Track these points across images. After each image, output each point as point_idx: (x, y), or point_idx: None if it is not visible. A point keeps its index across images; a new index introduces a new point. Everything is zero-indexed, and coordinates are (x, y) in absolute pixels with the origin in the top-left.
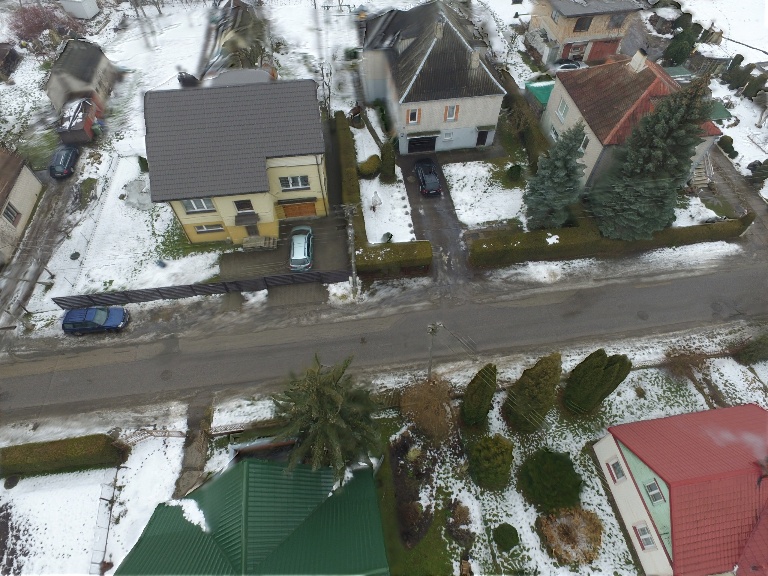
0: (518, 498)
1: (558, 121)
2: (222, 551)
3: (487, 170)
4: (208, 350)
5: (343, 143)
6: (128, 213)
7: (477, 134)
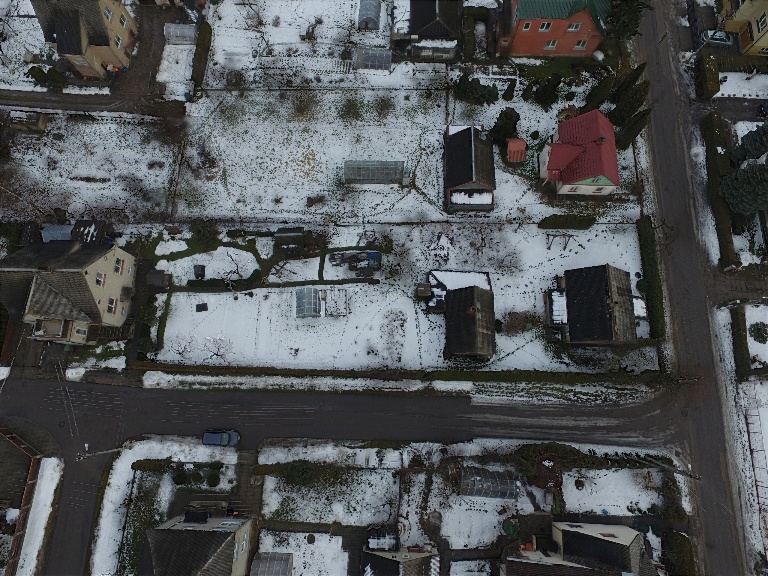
0: (583, 105)
1: None
2: None
3: None
4: (655, 3)
5: None
6: None
7: None
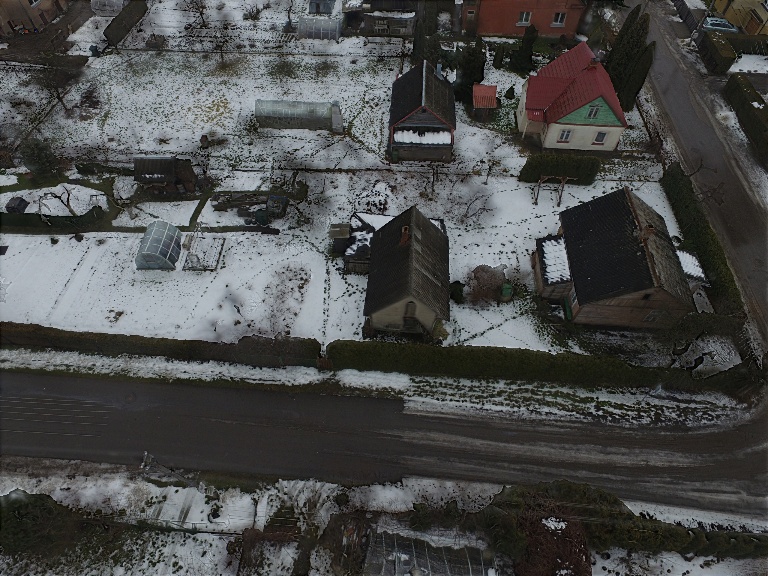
0: None
1: None
2: None
3: None
4: None
5: None
6: None
7: None
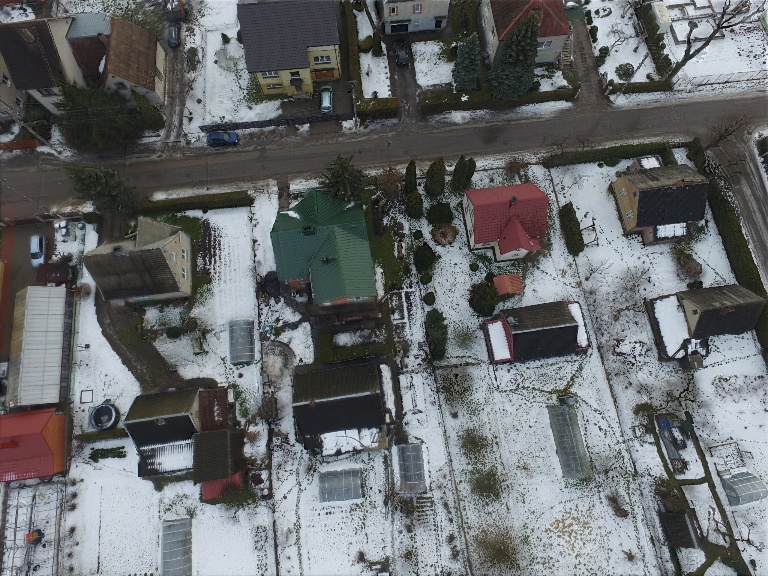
0: (426, 221)
1: (485, 15)
2: (308, 221)
3: (439, 48)
4: (282, 155)
5: (349, 27)
6: (222, 73)
7: (435, 21)
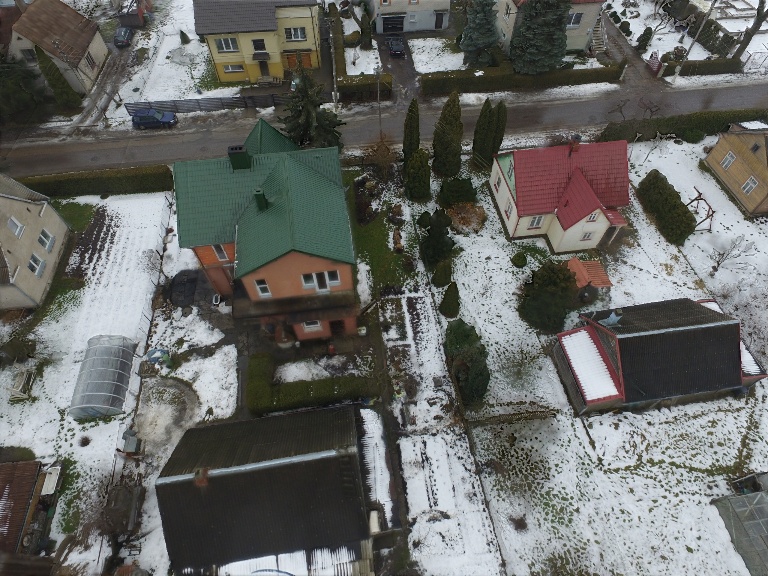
0: (436, 206)
1: (495, 5)
2: None
3: (441, 43)
4: (233, 137)
5: None
6: (173, 67)
7: (435, 17)
